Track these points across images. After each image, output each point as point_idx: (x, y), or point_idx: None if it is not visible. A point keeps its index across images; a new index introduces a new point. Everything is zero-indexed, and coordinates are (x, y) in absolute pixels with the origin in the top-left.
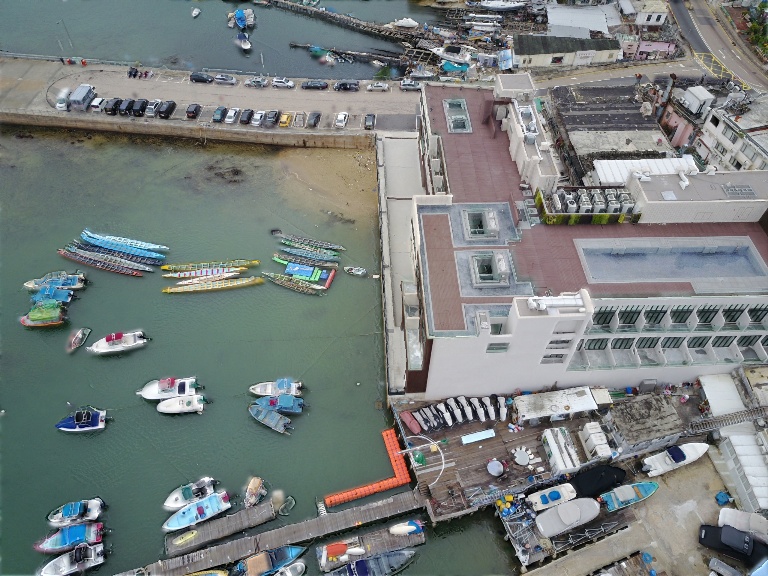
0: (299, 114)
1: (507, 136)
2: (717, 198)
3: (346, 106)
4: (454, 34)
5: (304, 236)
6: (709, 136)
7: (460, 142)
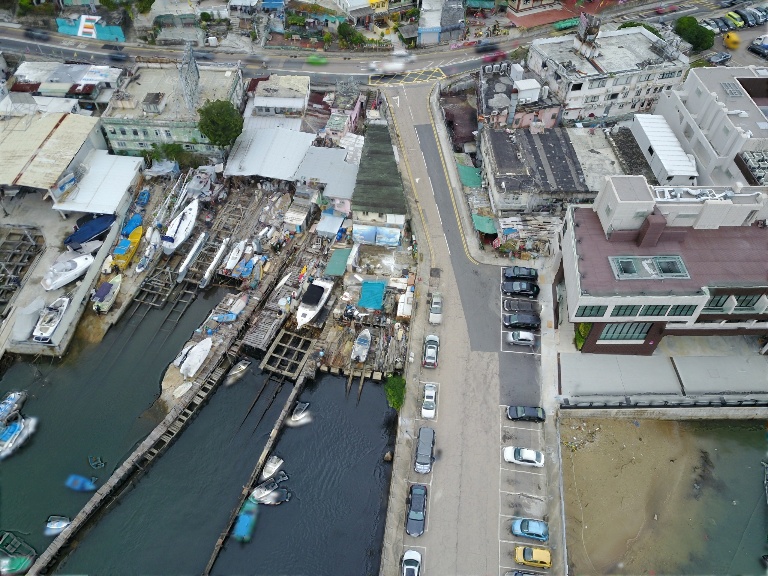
0: (523, 528)
1: (672, 227)
2: (748, 102)
3: (478, 452)
4: (236, 297)
5: (762, 519)
6: (575, 101)
7: (703, 270)
